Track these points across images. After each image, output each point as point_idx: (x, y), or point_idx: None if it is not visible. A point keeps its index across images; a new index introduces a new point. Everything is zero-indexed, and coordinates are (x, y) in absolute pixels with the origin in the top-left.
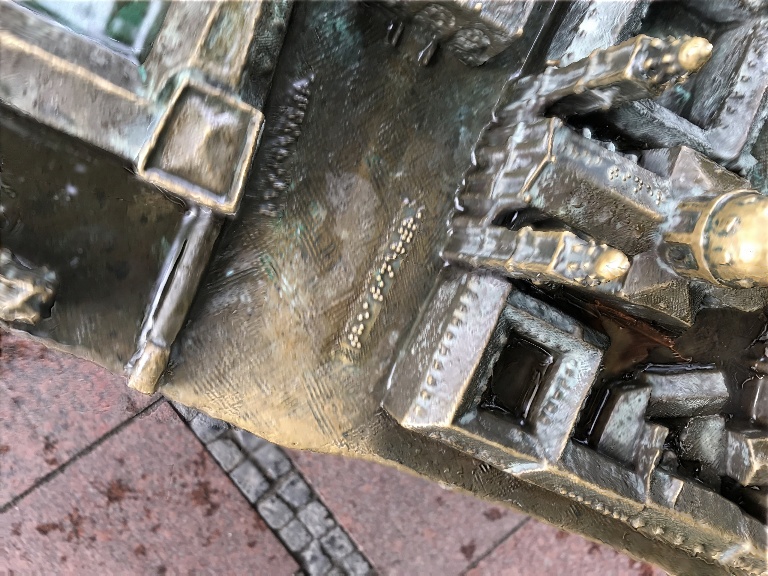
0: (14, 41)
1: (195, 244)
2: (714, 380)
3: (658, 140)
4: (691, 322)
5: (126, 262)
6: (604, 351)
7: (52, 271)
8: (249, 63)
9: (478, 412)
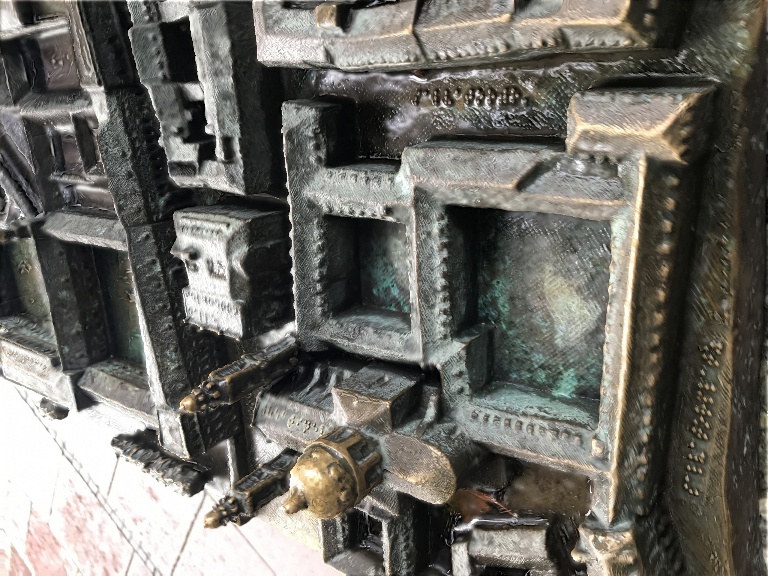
0: (123, 406)
1: (229, 453)
2: (534, 538)
3: (373, 356)
4: (393, 513)
5: (225, 458)
6: (391, 520)
7: (195, 471)
8: (168, 394)
9: (351, 552)
